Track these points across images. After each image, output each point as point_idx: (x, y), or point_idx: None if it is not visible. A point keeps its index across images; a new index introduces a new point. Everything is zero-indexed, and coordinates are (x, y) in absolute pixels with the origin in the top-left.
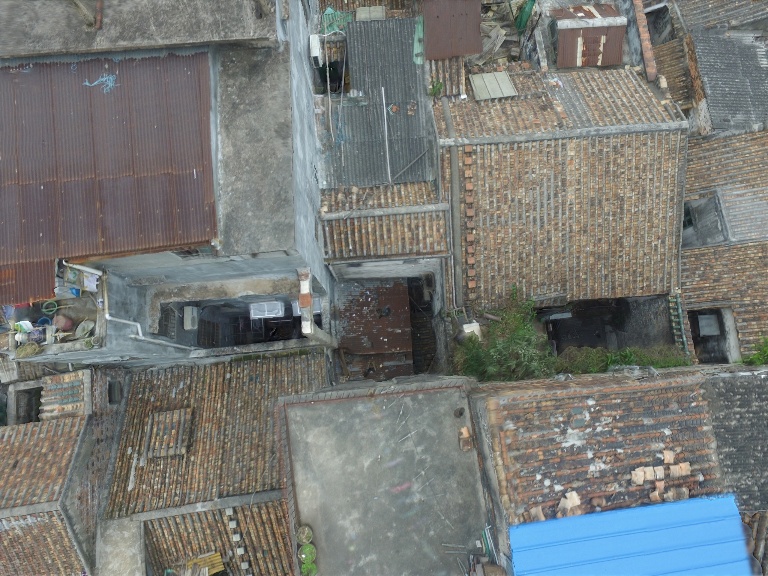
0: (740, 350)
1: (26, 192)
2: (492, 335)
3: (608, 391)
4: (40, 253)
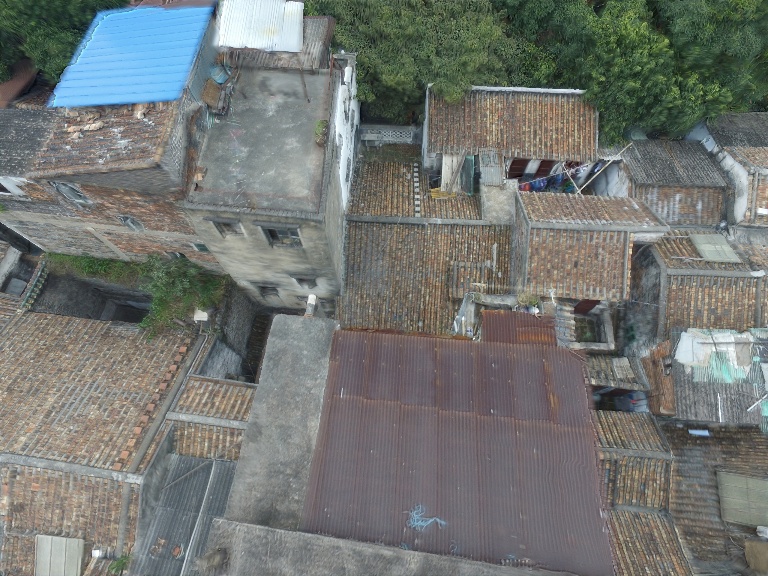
0: (5, 256)
1: (508, 409)
2: (186, 307)
3: (88, 167)
4: (494, 349)
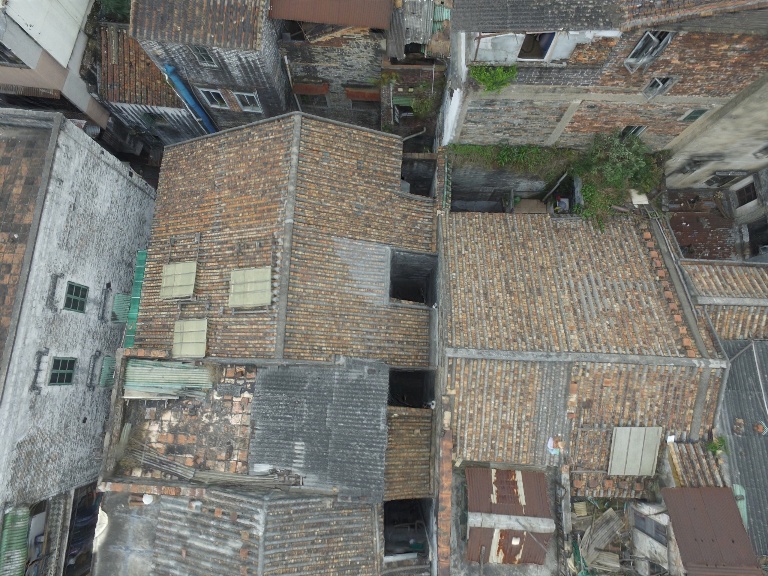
0: None
1: None
2: (624, 190)
3: (742, 2)
4: None
